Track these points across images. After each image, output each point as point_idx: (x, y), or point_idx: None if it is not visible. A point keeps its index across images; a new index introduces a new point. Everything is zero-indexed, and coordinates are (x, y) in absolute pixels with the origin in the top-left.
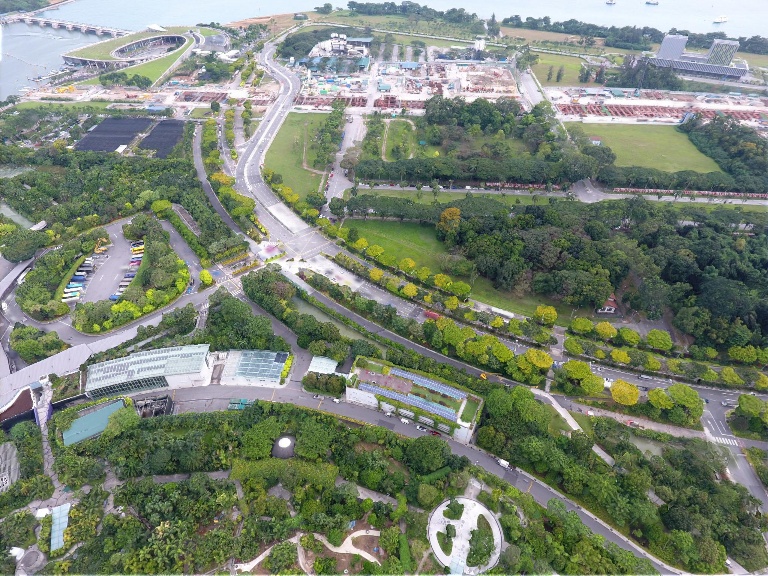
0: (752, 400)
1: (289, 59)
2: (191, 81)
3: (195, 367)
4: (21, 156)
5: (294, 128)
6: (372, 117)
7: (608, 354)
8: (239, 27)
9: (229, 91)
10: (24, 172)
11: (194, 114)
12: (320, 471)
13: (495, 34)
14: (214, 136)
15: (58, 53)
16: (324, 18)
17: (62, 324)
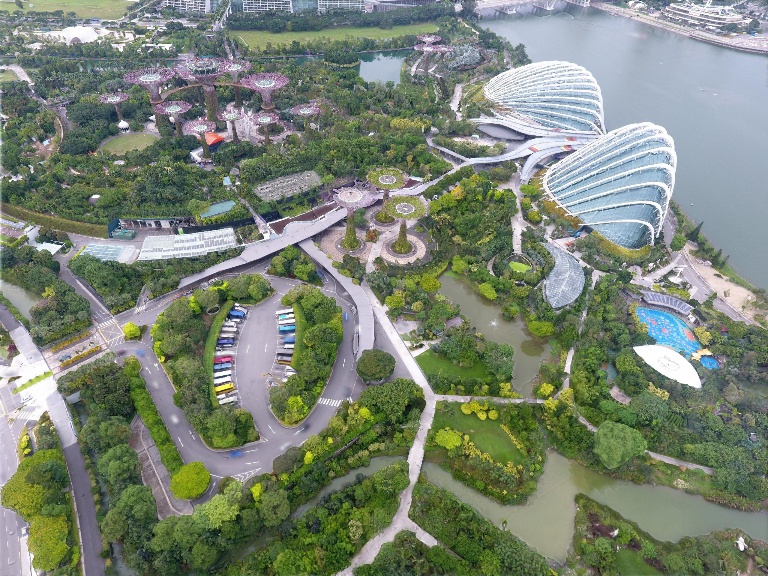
0: None
1: None
2: None
3: (150, 239)
4: None
5: None
6: None
7: None
8: None
9: None
10: None
11: None
12: (80, 187)
13: None
14: None
15: None
16: None
17: None
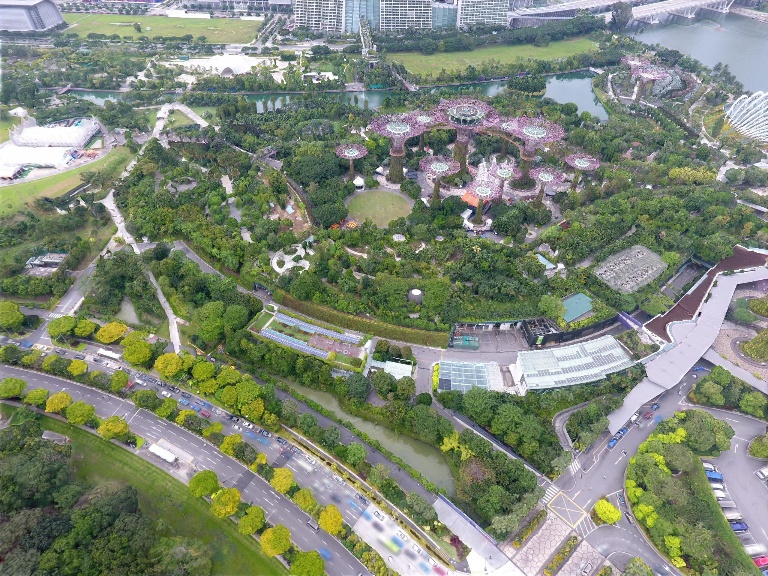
0: (6, 319)
1: None
2: None
3: (525, 356)
4: None
5: None
6: None
7: (87, 373)
8: None
9: None
10: None
11: None
12: (387, 277)
13: None
14: None
15: None
16: None
17: (738, 436)
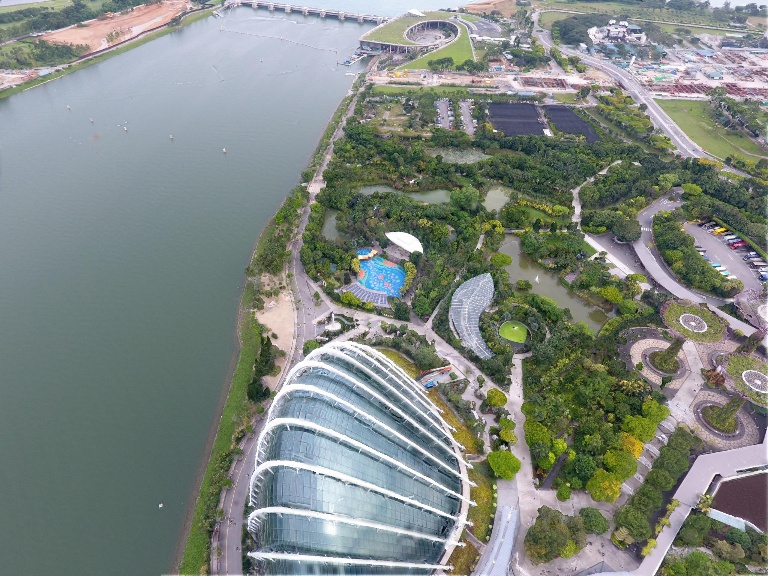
0: None
1: (575, 46)
2: (511, 67)
3: None
4: (469, 139)
5: (682, 114)
6: (743, 104)
7: None
8: (483, 13)
9: (563, 77)
10: (497, 155)
11: (564, 100)
12: None
13: (742, 22)
14: (638, 121)
15: (328, 38)
16: (547, 4)
17: None
